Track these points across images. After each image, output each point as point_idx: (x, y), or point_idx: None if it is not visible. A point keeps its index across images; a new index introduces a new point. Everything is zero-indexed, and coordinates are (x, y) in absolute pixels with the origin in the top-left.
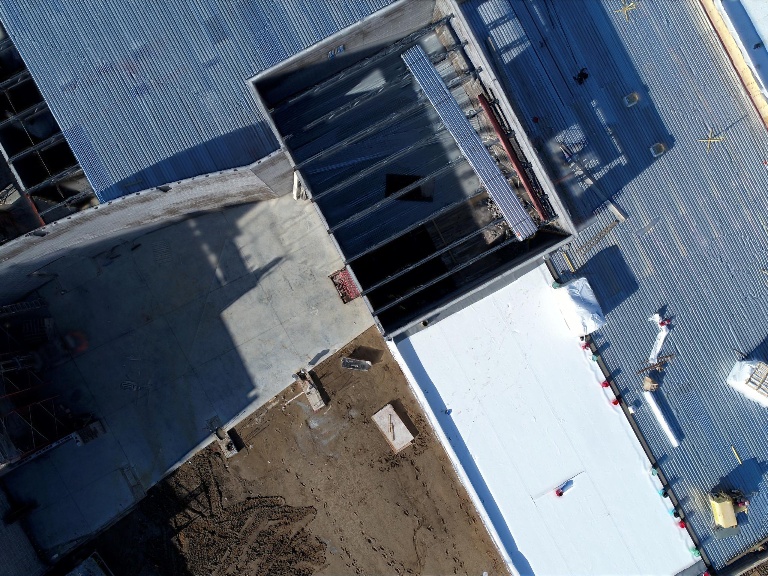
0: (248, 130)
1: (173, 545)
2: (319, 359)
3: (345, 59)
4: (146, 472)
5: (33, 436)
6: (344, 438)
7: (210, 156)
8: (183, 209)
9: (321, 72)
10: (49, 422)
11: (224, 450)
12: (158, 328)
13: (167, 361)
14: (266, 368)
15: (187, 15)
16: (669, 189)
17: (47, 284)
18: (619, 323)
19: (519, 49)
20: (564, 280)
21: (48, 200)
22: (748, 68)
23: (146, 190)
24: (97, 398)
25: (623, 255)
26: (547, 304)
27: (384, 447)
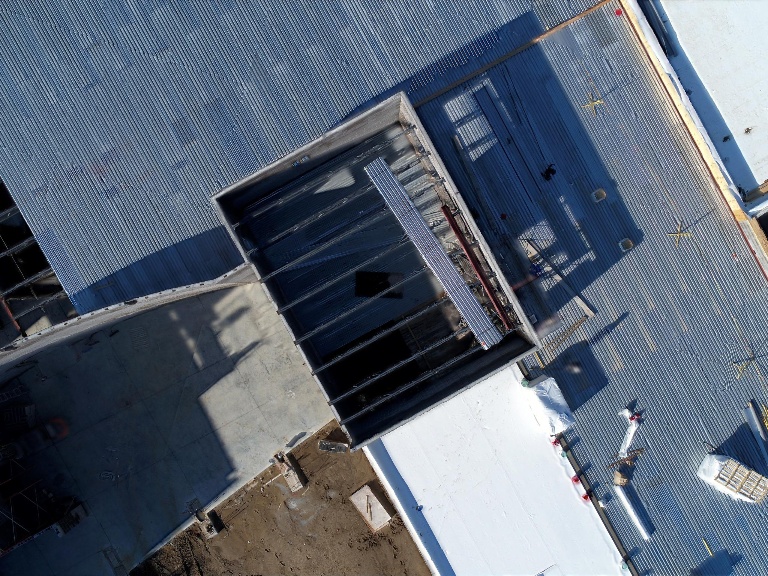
0: (218, 231)
1: None
2: (296, 441)
3: (312, 162)
4: (128, 554)
5: (14, 531)
6: (322, 518)
7: (181, 258)
8: (157, 304)
9: (288, 176)
10: (31, 511)
11: (204, 532)
12: (137, 413)
13: (147, 445)
14: (244, 451)
15: (155, 118)
16: (638, 283)
17: (28, 371)
18: (589, 417)
19: (487, 146)
20: (534, 376)
21: (24, 298)
22: (716, 164)
23: (114, 305)
24: (79, 482)
25: (592, 350)
26: (517, 400)
27: (362, 527)
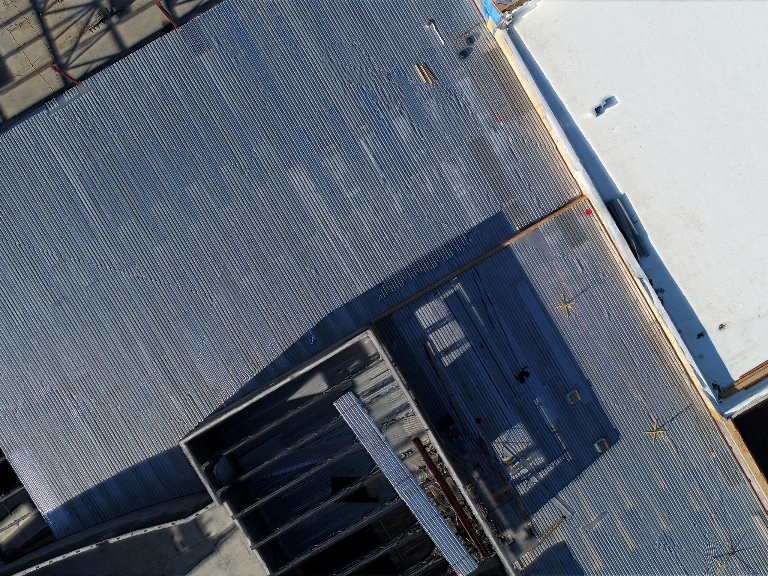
0: None
1: None
2: None
3: None
4: None
5: None
6: None
7: (154, 472)
8: None
9: None
10: None
11: None
12: None
13: None
14: None
15: (124, 333)
16: (615, 483)
17: None
18: None
19: (459, 351)
20: None
21: None
22: (690, 366)
23: (86, 548)
24: None
25: (571, 550)
26: None
27: None
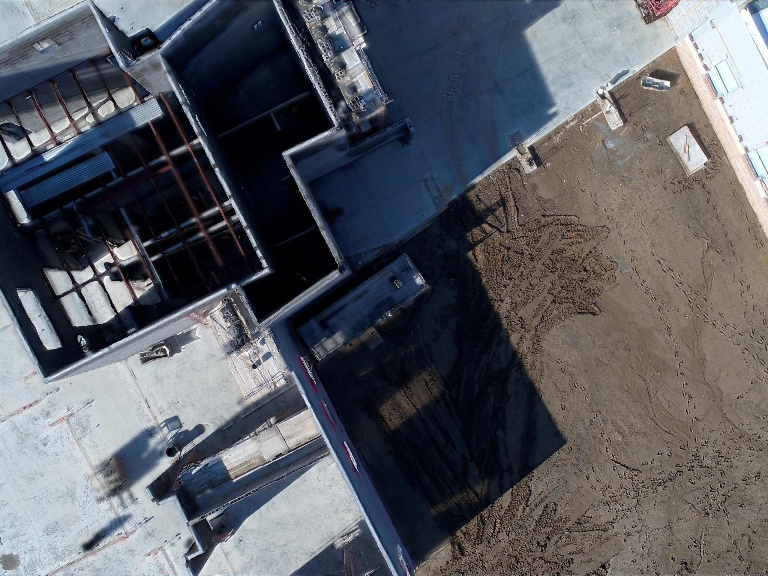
0: None
1: (469, 259)
2: (619, 79)
3: None
4: (448, 184)
5: None
6: (639, 159)
7: None
8: None
9: None
10: None
11: (524, 165)
12: (464, 43)
13: (471, 76)
14: (567, 86)
15: None
16: None
17: None
18: None
19: None
20: None
21: None
22: None
23: None
24: (403, 110)
25: None
26: None
27: (677, 169)
